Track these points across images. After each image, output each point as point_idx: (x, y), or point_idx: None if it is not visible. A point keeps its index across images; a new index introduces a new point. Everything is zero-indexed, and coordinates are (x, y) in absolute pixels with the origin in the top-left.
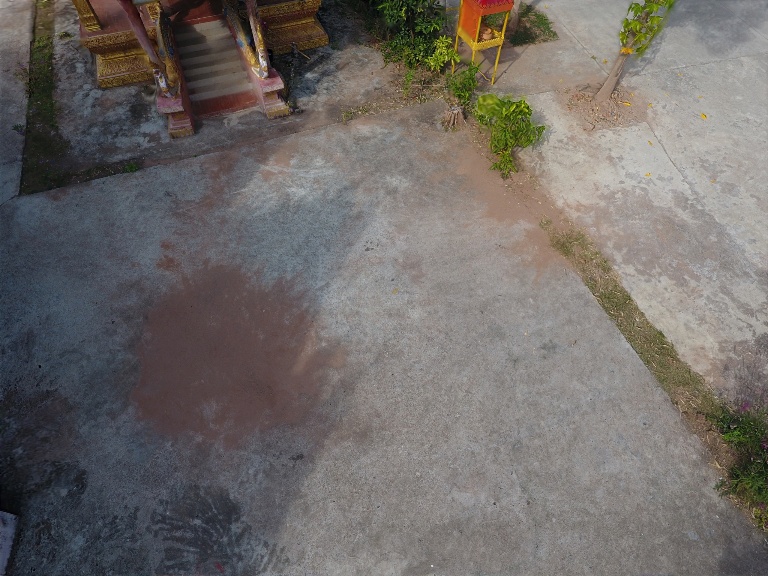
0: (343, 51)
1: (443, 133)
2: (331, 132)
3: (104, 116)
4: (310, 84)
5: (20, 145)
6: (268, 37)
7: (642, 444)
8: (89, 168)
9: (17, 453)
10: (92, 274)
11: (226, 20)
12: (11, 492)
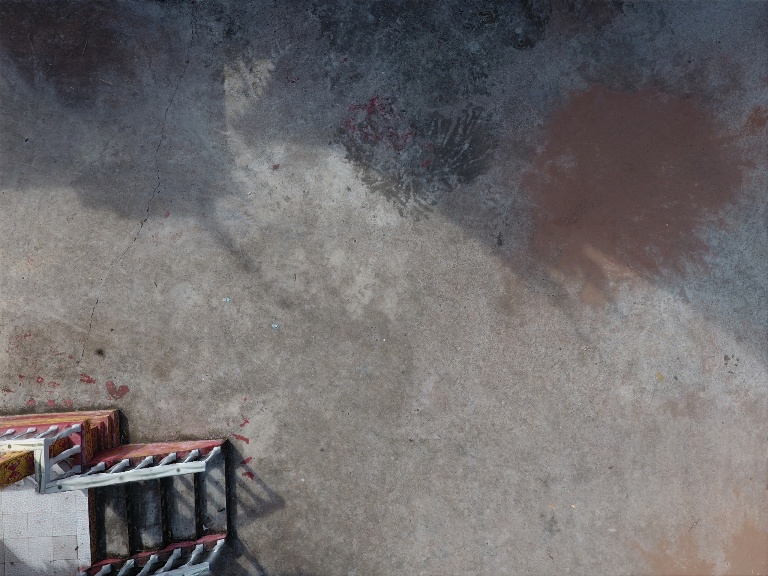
0: None
1: None
2: None
3: None
4: None
5: None
6: None
7: (434, 572)
8: None
9: None
10: (762, 34)
11: None
12: None
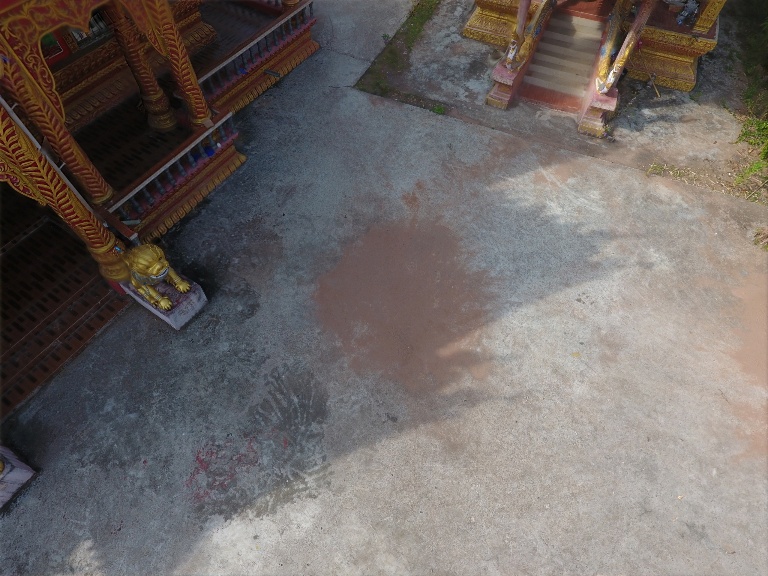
0: (700, 105)
1: (749, 244)
2: (627, 175)
3: (449, 58)
4: (641, 120)
5: (379, 51)
6: (633, 57)
7: None
8: (410, 93)
9: (234, 261)
10: (357, 173)
11: (606, 24)
12: (215, 283)
